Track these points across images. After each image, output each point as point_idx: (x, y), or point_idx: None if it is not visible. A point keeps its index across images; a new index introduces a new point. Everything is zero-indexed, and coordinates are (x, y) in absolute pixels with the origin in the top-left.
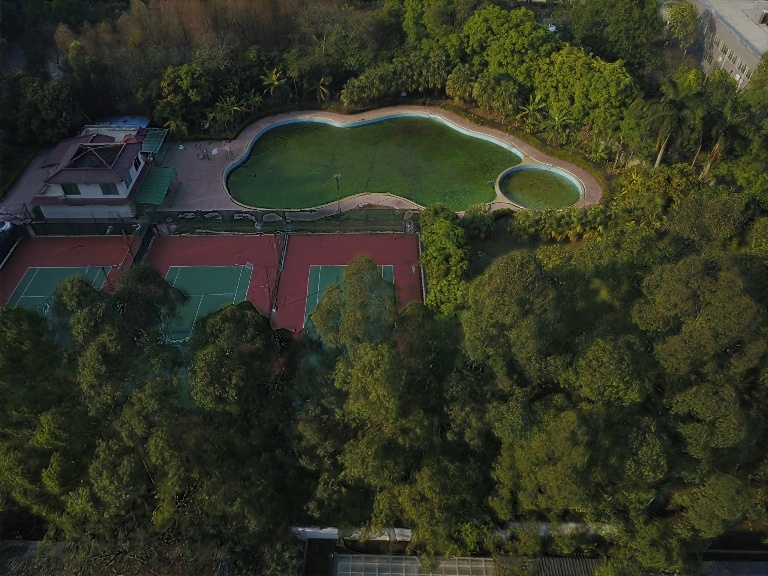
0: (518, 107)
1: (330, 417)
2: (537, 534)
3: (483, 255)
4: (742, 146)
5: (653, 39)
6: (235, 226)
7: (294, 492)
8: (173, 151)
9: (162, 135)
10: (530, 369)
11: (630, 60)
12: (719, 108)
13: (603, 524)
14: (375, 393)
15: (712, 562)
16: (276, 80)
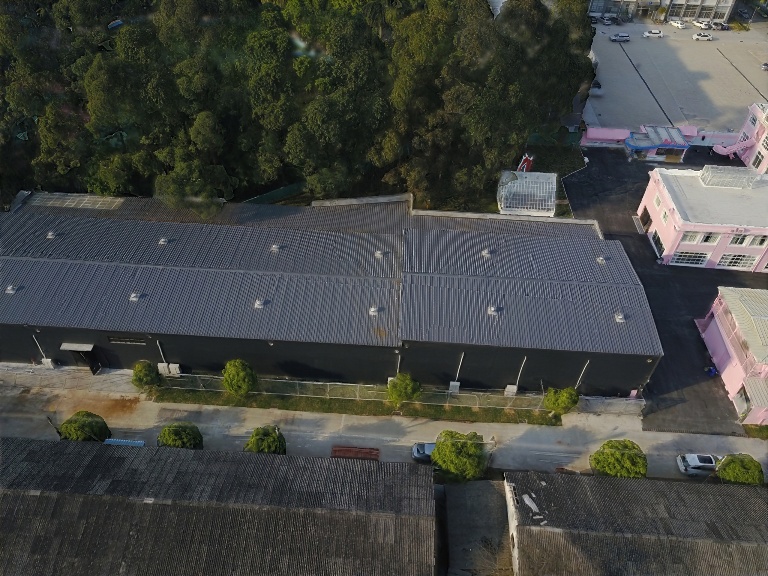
0: None
1: (2, 76)
2: (127, 160)
3: None
4: None
5: None
6: None
7: (18, 163)
8: None
9: None
10: (91, 39)
11: None
12: None
13: None
14: (1, 38)
15: (251, 204)
16: None
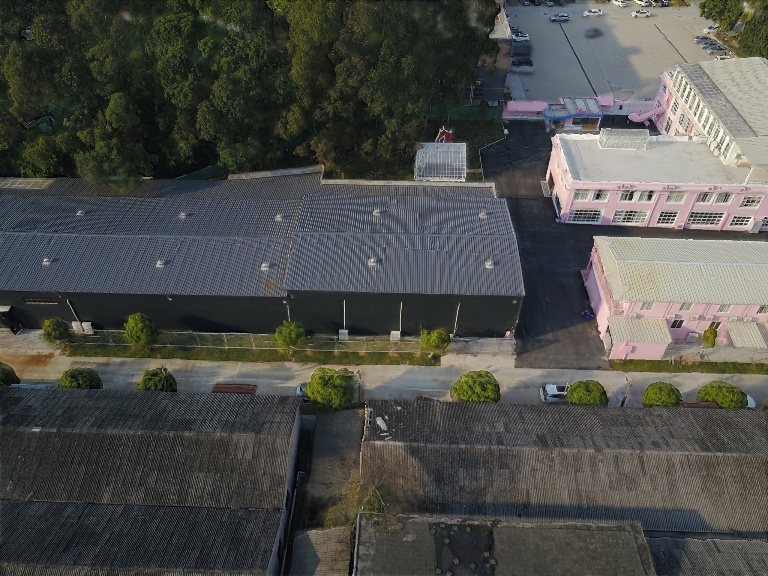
0: None
1: None
2: (52, 141)
3: None
4: None
5: None
6: None
7: None
8: None
9: None
10: (8, 29)
11: None
12: None
13: None
14: None
15: (173, 179)
16: None
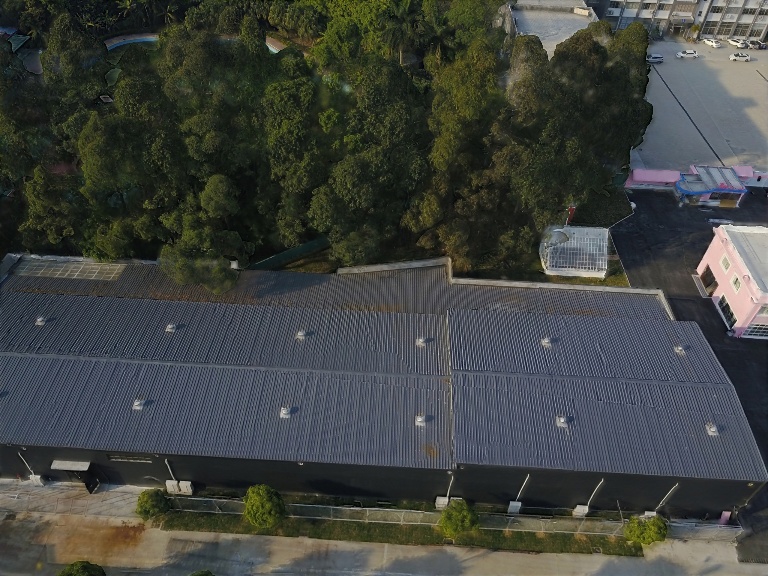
0: (318, 33)
1: None
2: (128, 226)
3: None
4: (452, 56)
5: None
6: None
7: (4, 224)
8: (33, 55)
9: (23, 40)
10: (86, 93)
11: (420, 2)
12: (431, 24)
13: (166, 219)
14: None
15: (269, 271)
16: (129, 5)
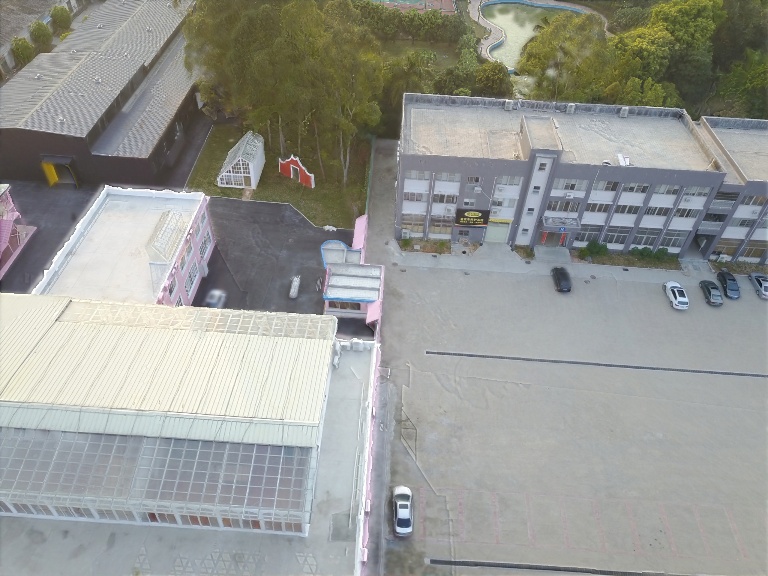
0: None
1: None
2: None
3: (444, 57)
4: None
5: (764, 95)
6: (461, 1)
7: None
8: None
9: None
10: None
11: None
12: None
13: None
14: None
15: None
16: None
